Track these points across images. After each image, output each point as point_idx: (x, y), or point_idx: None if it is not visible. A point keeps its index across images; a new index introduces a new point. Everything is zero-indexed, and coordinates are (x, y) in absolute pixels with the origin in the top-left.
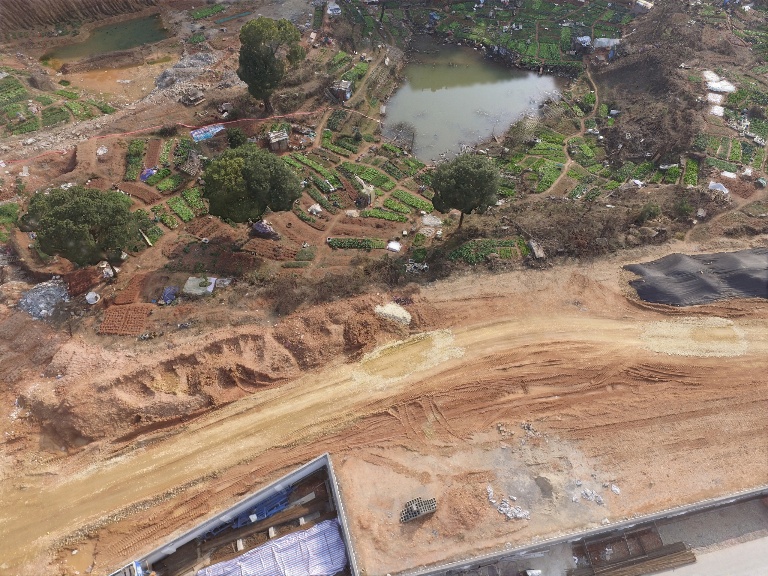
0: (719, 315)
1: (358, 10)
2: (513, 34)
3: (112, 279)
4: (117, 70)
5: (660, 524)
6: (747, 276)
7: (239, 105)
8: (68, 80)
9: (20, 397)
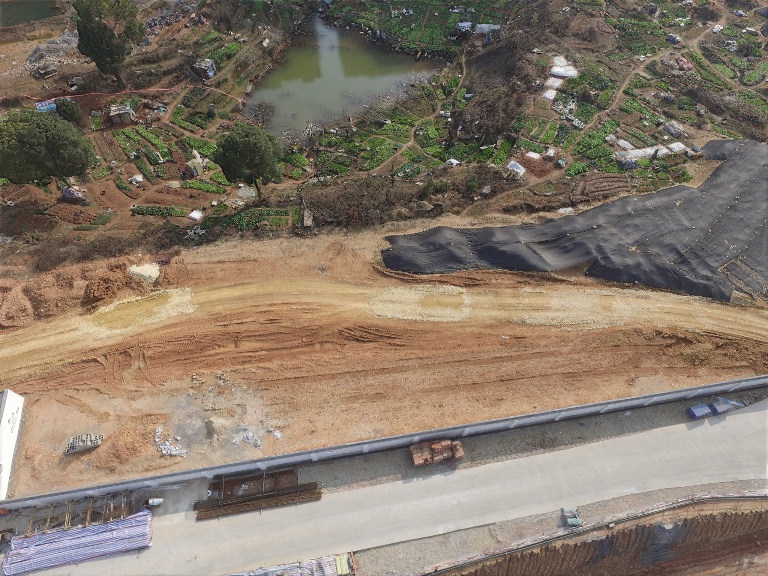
0: (455, 284)
1: None
2: (402, 19)
3: None
4: None
5: (303, 466)
6: (495, 248)
7: (91, 79)
8: None
9: None
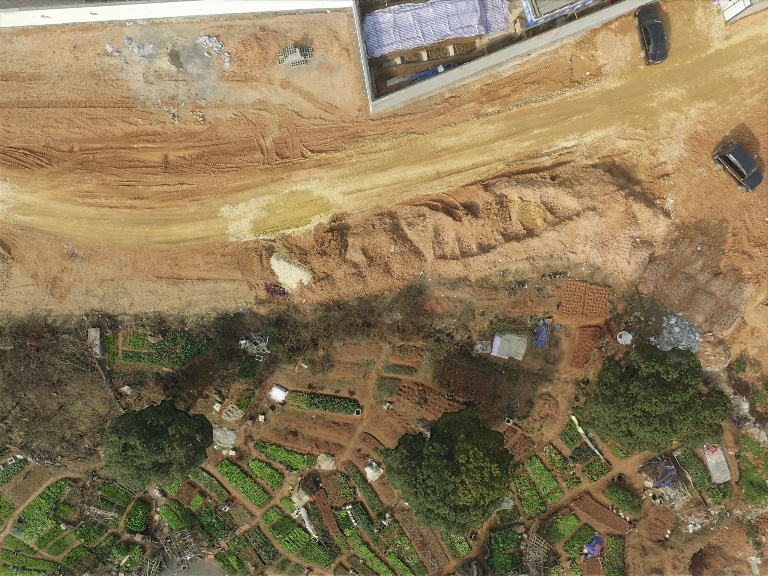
0: None
1: None
2: None
3: None
4: None
5: None
6: None
7: None
8: None
9: (670, 218)
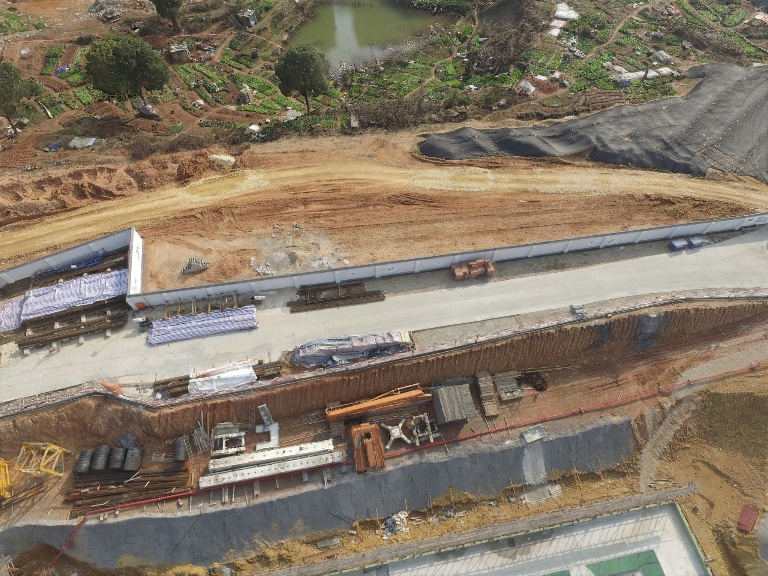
0: (480, 166)
1: None
2: None
3: (12, 135)
4: (59, 0)
5: (368, 280)
6: (512, 140)
7: (150, 24)
8: (16, 7)
9: None
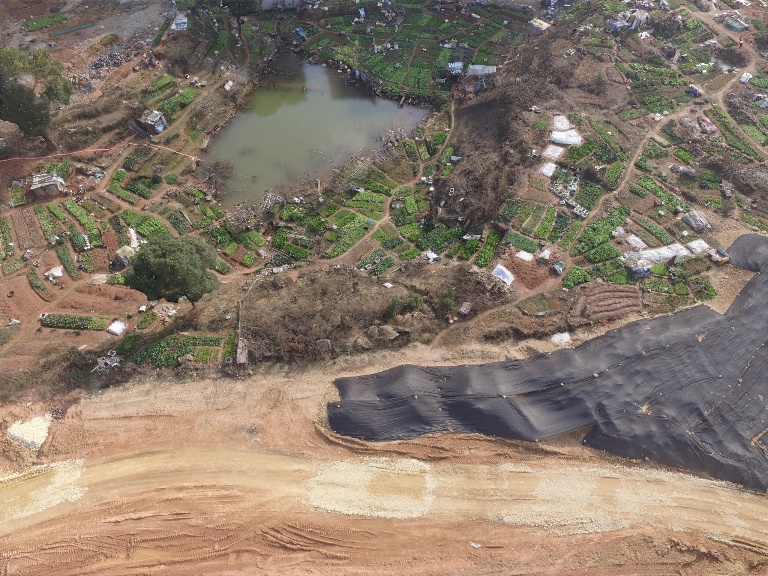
0: (417, 457)
1: (215, 23)
2: (386, 55)
3: None
4: None
5: None
6: (469, 405)
7: (14, 141)
8: None
9: None
